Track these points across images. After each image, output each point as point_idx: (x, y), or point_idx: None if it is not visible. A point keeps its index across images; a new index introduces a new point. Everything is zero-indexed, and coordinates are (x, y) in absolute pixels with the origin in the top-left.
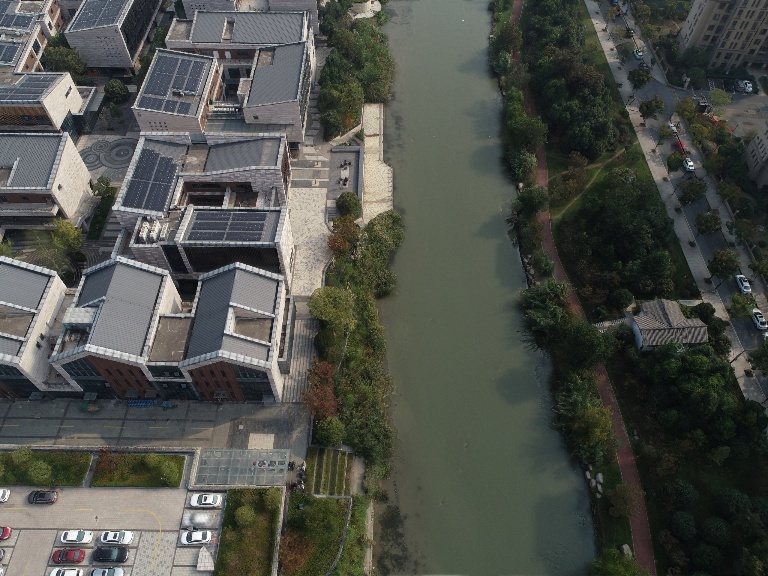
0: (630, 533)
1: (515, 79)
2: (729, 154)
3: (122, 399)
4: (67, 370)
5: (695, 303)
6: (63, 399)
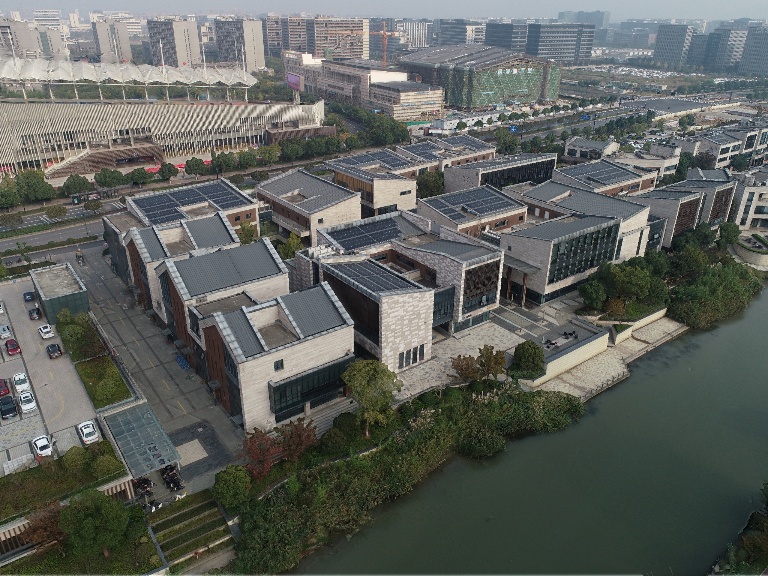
0: None
1: None
2: None
3: (181, 353)
4: None
5: None
6: None
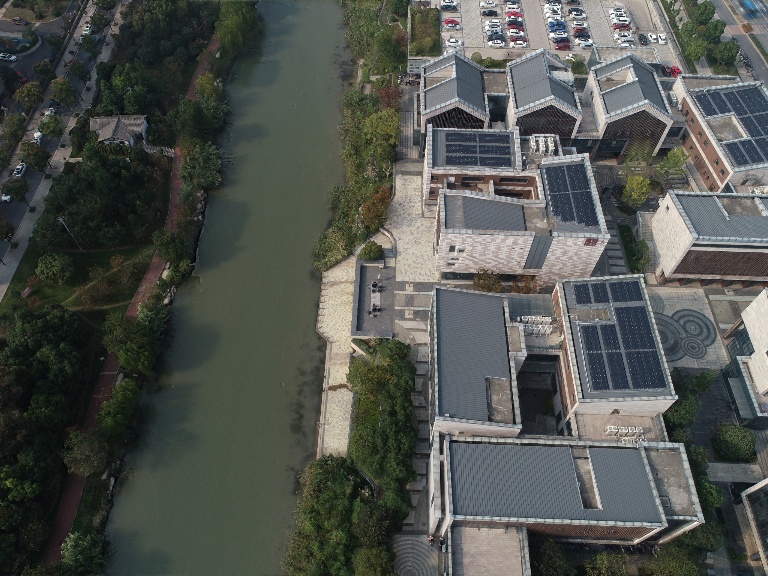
0: None
1: None
2: None
3: None
4: None
5: (76, 160)
6: None
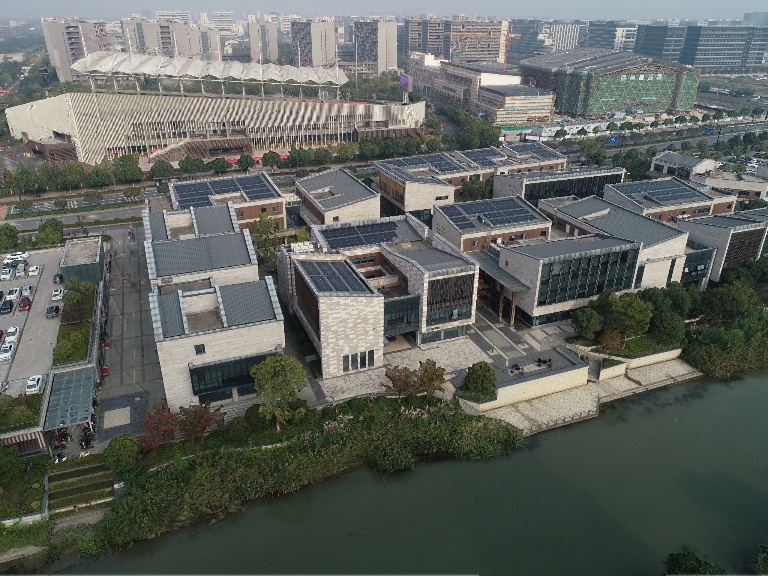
0: None
1: None
2: None
3: None
4: None
5: None
6: None
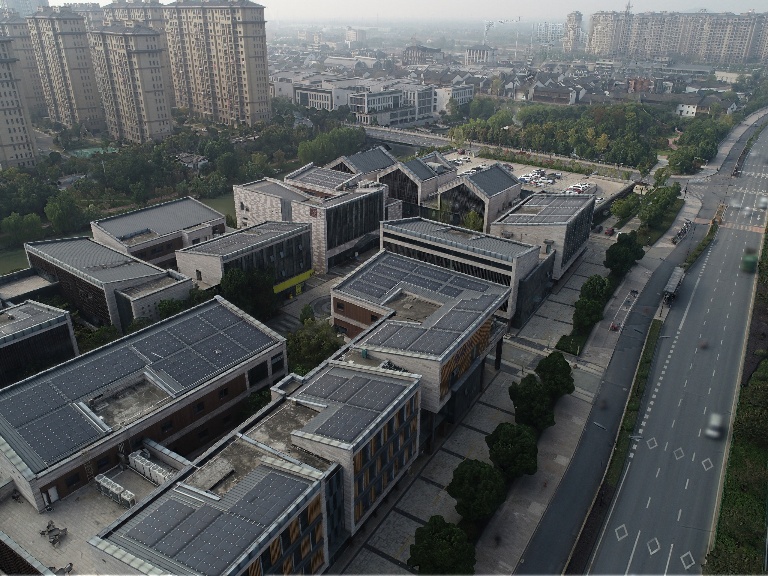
0: None
1: None
2: (28, 168)
3: None
4: None
5: None
6: None
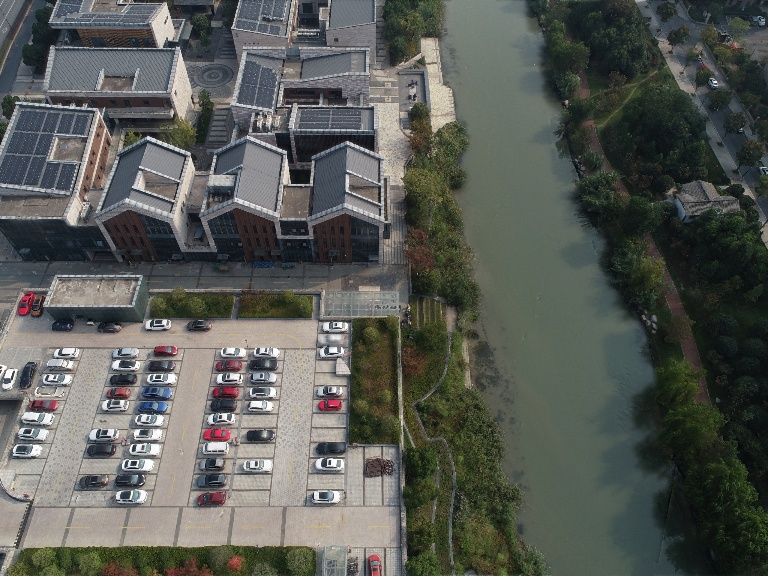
0: (682, 356)
1: (557, 13)
2: (749, 71)
3: (247, 262)
4: (210, 227)
5: None
6: (196, 262)
